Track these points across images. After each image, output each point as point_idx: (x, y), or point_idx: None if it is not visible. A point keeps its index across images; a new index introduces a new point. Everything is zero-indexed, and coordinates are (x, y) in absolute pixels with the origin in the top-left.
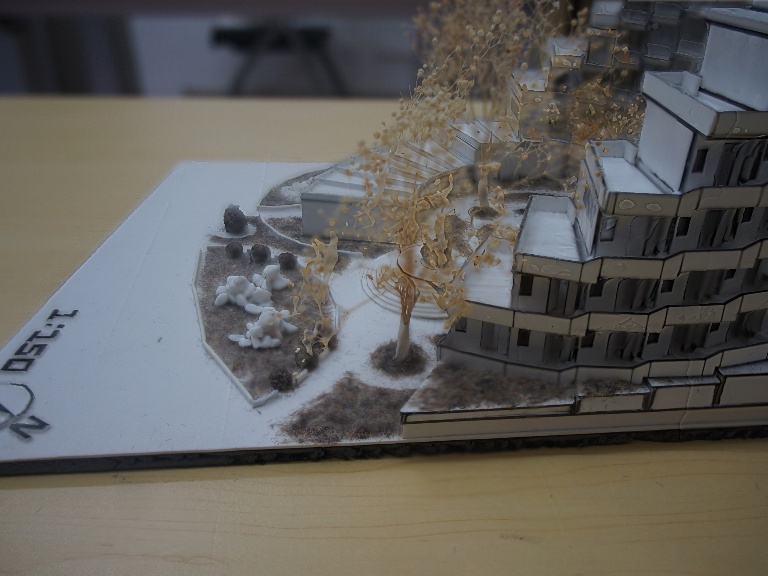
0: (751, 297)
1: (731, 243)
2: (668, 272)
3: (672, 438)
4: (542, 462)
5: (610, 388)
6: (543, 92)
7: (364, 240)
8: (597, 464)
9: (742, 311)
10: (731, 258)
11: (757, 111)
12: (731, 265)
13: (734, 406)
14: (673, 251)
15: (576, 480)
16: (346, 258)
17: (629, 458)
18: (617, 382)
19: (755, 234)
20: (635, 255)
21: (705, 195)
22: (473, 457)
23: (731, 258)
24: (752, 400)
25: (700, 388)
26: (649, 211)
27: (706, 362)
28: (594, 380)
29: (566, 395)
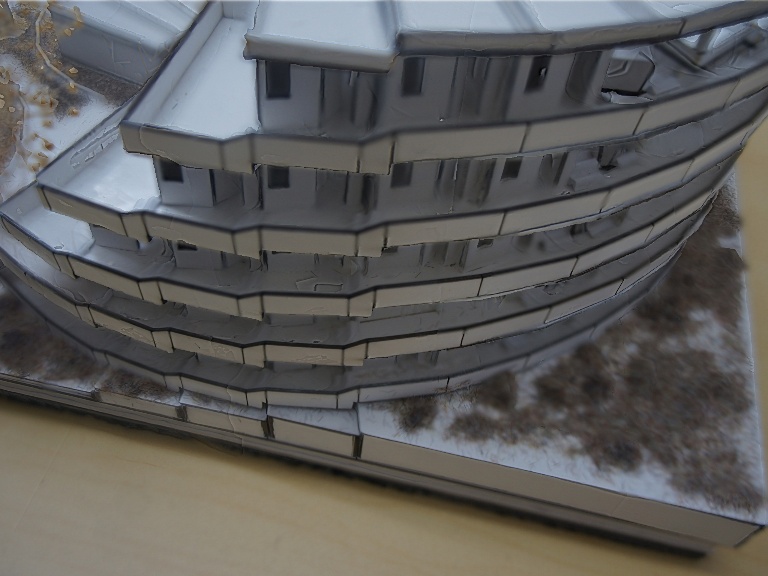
0: (277, 349)
1: (258, 276)
2: (150, 295)
3: (235, 450)
4: (72, 435)
5: (133, 389)
6: None
7: (124, 77)
8: (127, 456)
9: (271, 359)
10: (225, 303)
11: (173, 134)
12: (230, 310)
13: (293, 445)
14: (180, 265)
15: (86, 470)
16: (83, 99)
17: (168, 459)
18: (146, 383)
19: (311, 267)
20: (149, 252)
21: (152, 223)
22: (5, 406)
23: (225, 303)
24: (317, 445)
25: (242, 419)
26: (95, 219)
27: (248, 395)
28: (125, 372)
29: (88, 380)
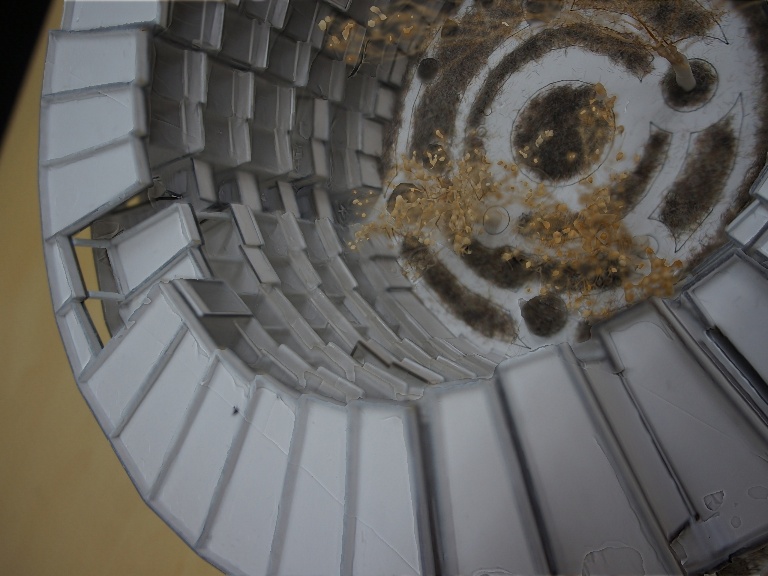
0: None
1: None
2: None
3: None
4: None
5: None
6: (752, 238)
7: None
8: None
9: None
10: None
11: None
12: None
13: None
14: None
15: None
16: None
17: None
18: None
19: None
20: None
21: None
22: None
23: None
24: None
25: None
26: None
27: None
28: None
29: None
